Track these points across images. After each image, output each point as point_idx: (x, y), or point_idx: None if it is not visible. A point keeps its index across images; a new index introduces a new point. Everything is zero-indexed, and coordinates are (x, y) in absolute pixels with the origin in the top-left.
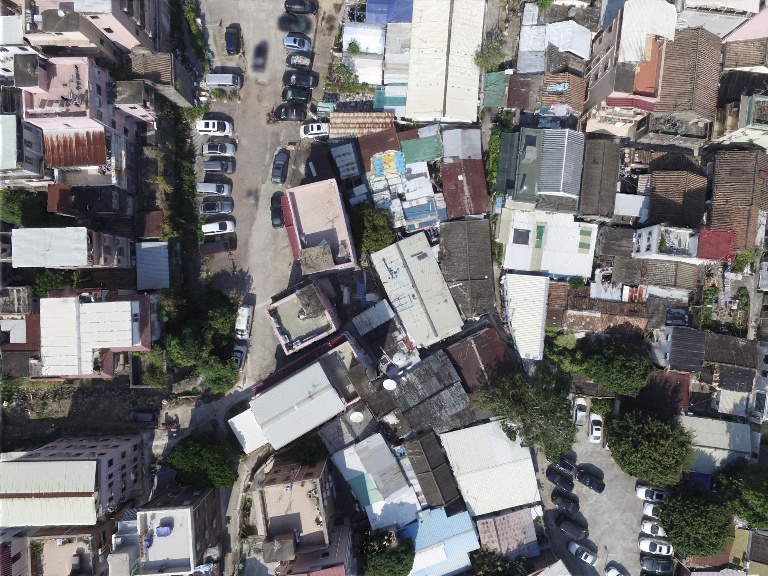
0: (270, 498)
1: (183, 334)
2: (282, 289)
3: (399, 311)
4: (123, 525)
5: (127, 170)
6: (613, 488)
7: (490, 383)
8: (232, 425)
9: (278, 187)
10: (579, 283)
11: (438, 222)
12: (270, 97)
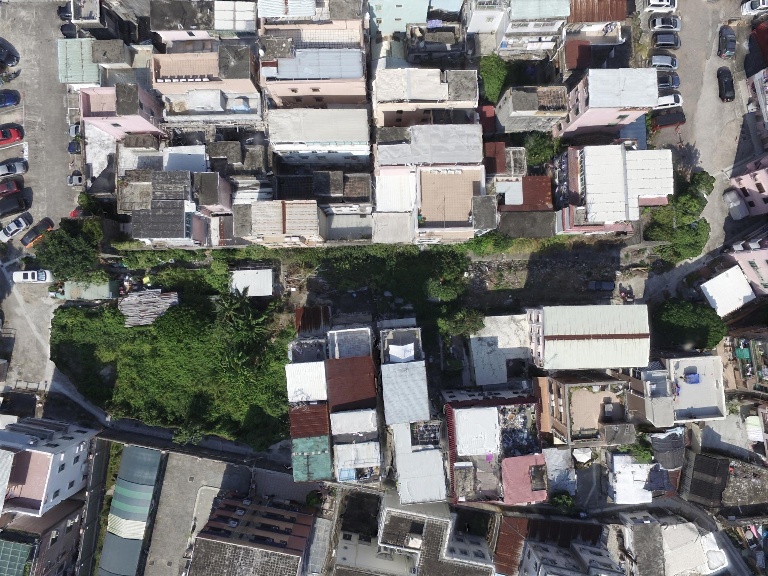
0: None
1: (690, 191)
2: (729, 162)
3: None
4: (648, 375)
5: None
6: None
7: None
8: (704, 290)
9: (723, 62)
10: None
11: None
12: None
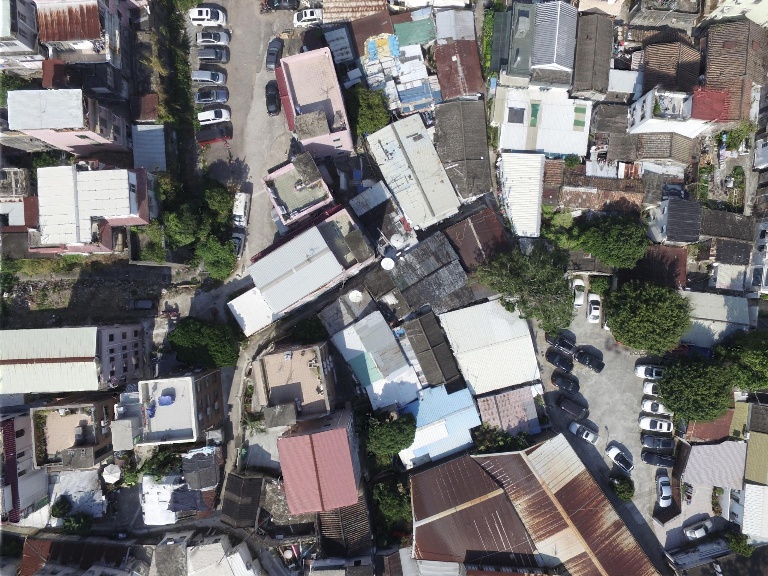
0: (271, 368)
1: (181, 209)
2: None
3: (396, 193)
4: (125, 397)
5: (121, 51)
6: (613, 369)
7: (488, 261)
8: (232, 308)
9: (273, 76)
10: (575, 160)
11: (433, 104)
12: None
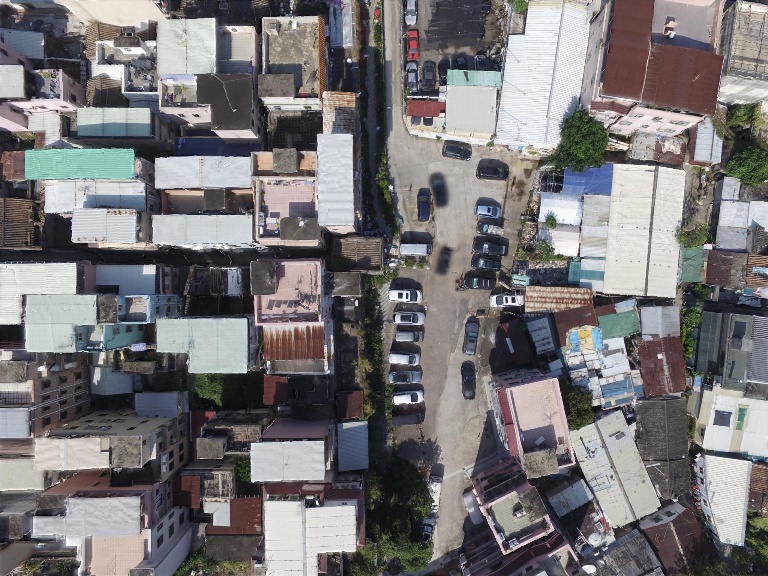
0: None
1: (394, 526)
2: (471, 460)
3: (596, 491)
4: None
5: None
6: None
7: (689, 567)
8: None
9: (468, 356)
10: None
11: (635, 399)
12: (459, 263)
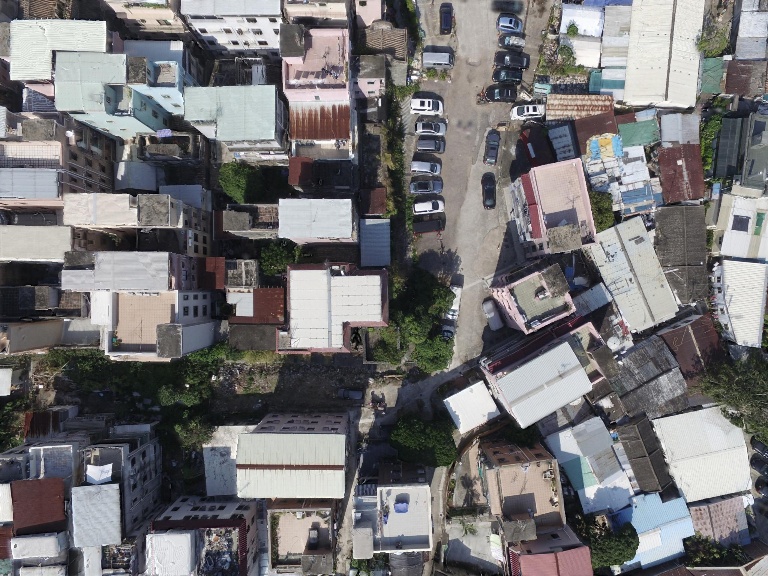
0: (505, 477)
1: (416, 311)
2: (490, 270)
3: (615, 295)
4: (359, 500)
5: (357, 146)
6: None
7: (706, 369)
8: (448, 405)
9: (488, 168)
10: None
11: (654, 207)
12: (480, 78)
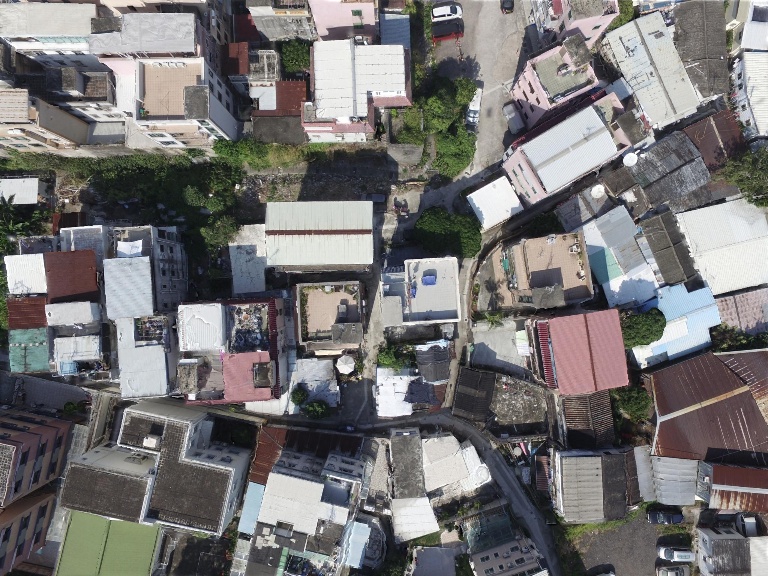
0: (531, 253)
1: (439, 94)
2: (510, 76)
3: (635, 90)
4: (386, 277)
5: None
6: None
7: (729, 160)
8: (471, 201)
9: None
10: None
11: (673, 3)
12: None
